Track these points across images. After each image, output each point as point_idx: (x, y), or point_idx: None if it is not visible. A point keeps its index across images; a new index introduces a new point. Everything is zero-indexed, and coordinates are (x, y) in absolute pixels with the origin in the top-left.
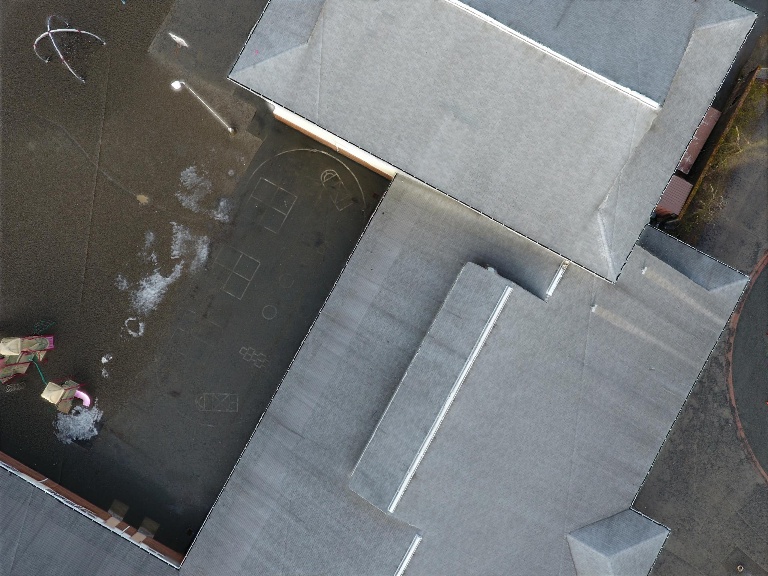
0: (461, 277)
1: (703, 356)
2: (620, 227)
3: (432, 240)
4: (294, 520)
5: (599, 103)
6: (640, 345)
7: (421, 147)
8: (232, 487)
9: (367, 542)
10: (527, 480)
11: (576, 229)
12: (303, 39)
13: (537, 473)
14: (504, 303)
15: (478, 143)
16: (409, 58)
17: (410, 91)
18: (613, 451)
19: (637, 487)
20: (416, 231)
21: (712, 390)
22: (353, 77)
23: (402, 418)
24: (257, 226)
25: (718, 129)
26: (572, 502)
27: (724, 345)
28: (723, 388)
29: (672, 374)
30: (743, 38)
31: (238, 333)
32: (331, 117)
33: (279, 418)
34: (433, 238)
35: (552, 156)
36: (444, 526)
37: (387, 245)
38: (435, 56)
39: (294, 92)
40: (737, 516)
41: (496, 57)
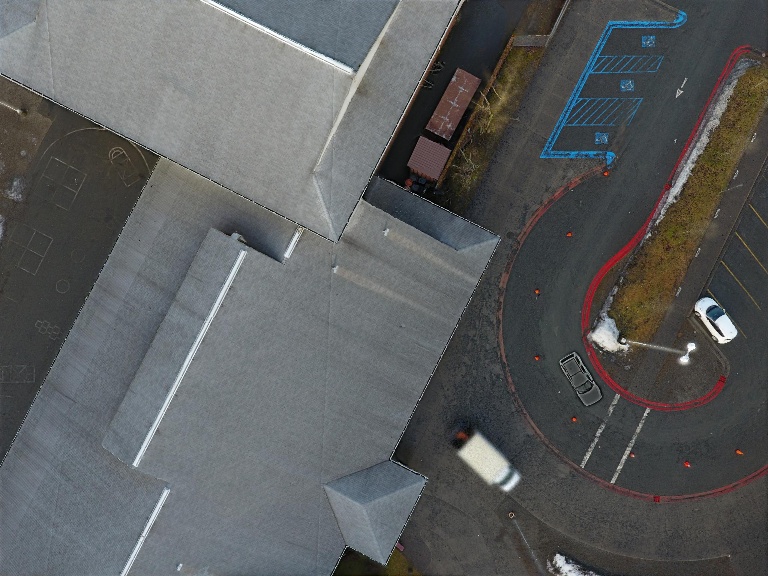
0: (204, 243)
1: (456, 313)
2: (338, 189)
3: (191, 210)
4: (64, 480)
5: (299, 70)
6: (388, 304)
7: (149, 118)
8: (14, 452)
9: (124, 497)
10: (277, 434)
11: (296, 192)
12: (32, 18)
13: (287, 427)
14: (239, 266)
15: (199, 113)
16: (127, 33)
17: (132, 65)
18: (367, 405)
19: (395, 439)
20: (178, 202)
21: (484, 347)
22: (80, 53)
23: (149, 378)
24: (49, 204)
25: (476, 96)
26: (327, 454)
27: (494, 304)
28: (494, 345)
29: (424, 331)
30: (455, 4)
31: (33, 307)
32: (65, 92)
33: (56, 385)
34: (192, 208)
35: (265, 123)
36: (193, 479)
37: (153, 216)
38: (149, 30)
39: (29, 69)
40: (508, 466)
41: (203, 29)
